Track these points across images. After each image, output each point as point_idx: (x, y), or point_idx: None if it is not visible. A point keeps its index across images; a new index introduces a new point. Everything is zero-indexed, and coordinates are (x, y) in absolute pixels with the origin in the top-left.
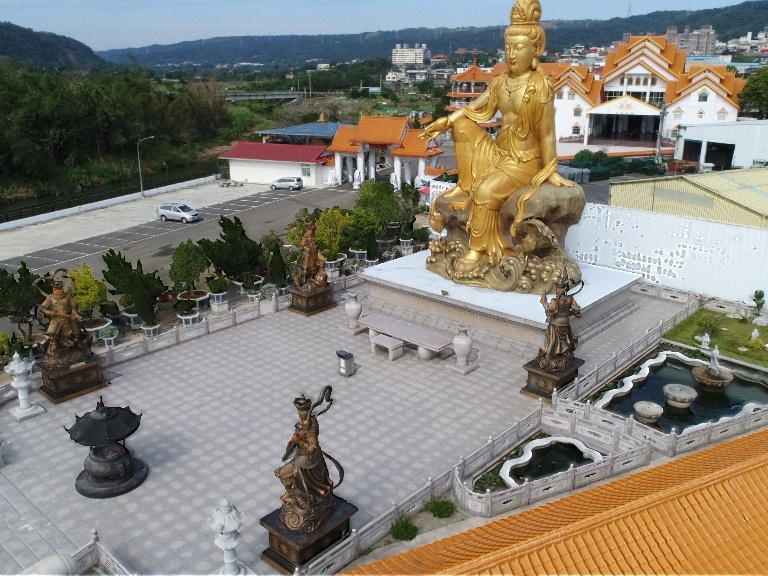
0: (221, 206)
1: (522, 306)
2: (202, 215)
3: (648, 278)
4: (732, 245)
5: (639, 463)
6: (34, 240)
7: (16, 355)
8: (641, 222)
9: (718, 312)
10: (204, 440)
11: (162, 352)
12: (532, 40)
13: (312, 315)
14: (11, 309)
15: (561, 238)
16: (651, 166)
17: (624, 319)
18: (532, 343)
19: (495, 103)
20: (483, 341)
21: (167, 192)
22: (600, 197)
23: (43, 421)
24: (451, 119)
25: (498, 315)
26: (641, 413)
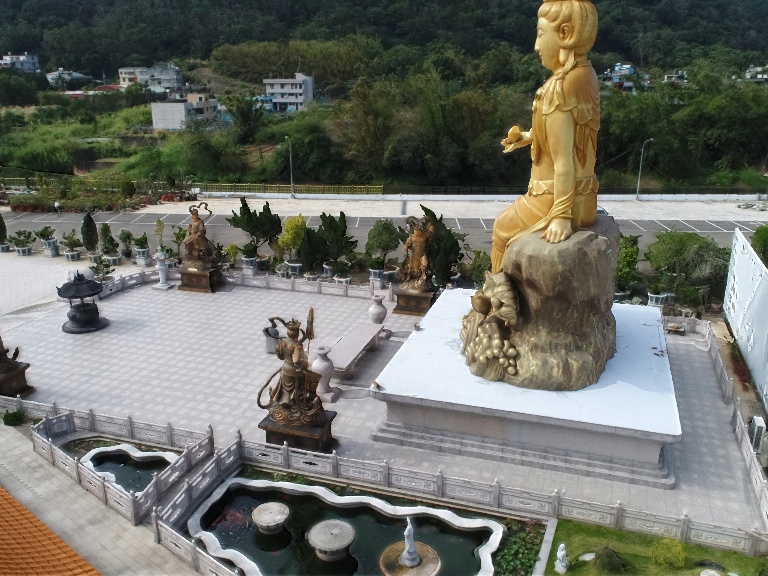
0: (671, 222)
1: (419, 368)
2: (628, 225)
3: None
4: None
5: (129, 515)
6: (468, 211)
7: (159, 247)
8: None
9: None
10: (140, 334)
11: (276, 291)
12: (552, 23)
13: (397, 313)
14: (258, 233)
15: (548, 315)
16: None
17: (599, 479)
18: None
19: None
20: None
21: (672, 201)
22: None
23: (155, 293)
24: None
25: None
26: None
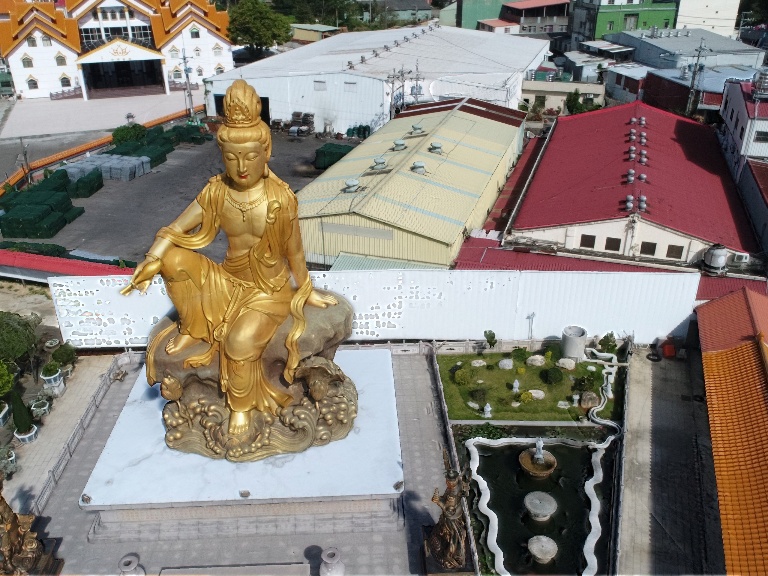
0: None
1: (346, 472)
2: None
3: (354, 326)
4: (448, 289)
5: None
6: None
7: None
8: (352, 283)
9: (450, 355)
10: None
11: None
12: (263, 144)
13: None
14: None
15: None
16: (199, 134)
17: None
18: (375, 511)
19: (217, 223)
20: (314, 530)
21: None
22: (184, 195)
23: None
24: (158, 255)
25: (333, 500)
26: (545, 559)
